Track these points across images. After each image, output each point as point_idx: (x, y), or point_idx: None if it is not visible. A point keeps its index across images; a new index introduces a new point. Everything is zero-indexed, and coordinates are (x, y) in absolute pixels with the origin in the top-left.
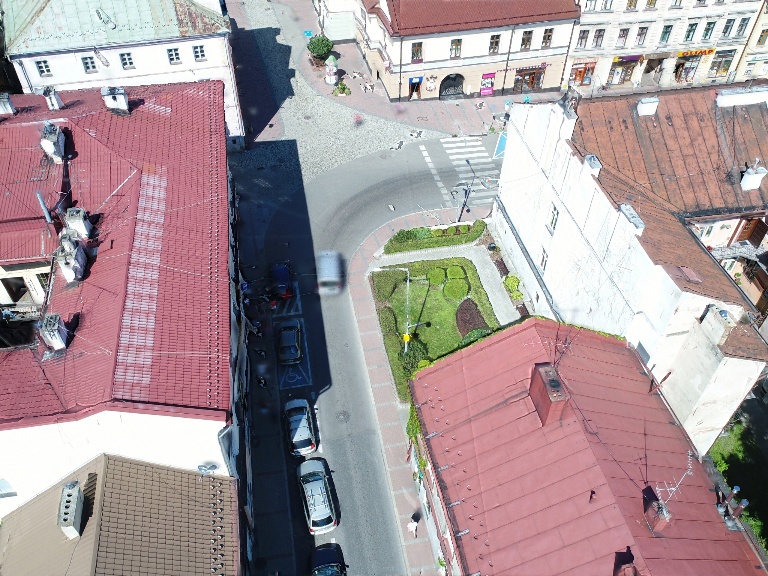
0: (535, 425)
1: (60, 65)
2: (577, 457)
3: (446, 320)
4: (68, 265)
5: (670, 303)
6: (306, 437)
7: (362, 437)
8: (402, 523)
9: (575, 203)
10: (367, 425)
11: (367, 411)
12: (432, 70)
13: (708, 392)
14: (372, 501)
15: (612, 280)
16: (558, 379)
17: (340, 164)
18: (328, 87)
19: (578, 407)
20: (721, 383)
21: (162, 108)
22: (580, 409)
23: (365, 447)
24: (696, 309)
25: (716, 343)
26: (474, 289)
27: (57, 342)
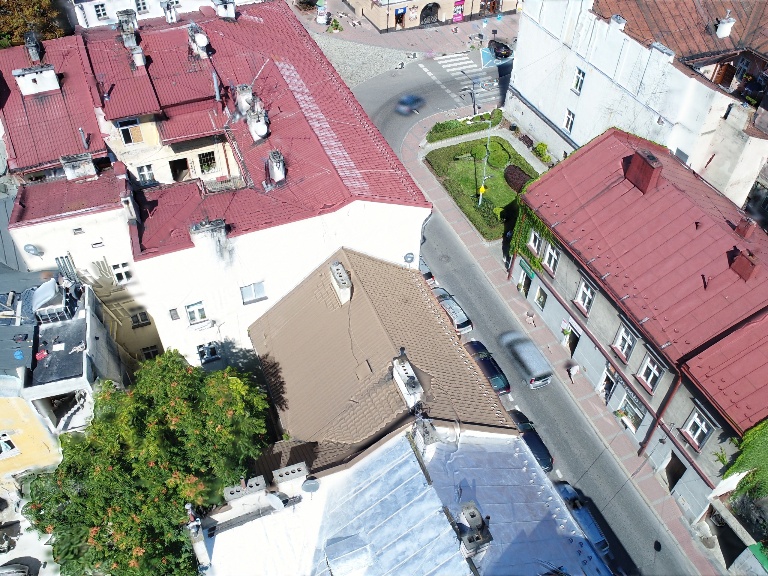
0: (637, 196)
1: (116, 7)
2: (677, 206)
3: (498, 182)
4: (259, 123)
5: (705, 105)
6: (427, 271)
7: (466, 270)
8: (521, 319)
9: (603, 59)
10: (466, 261)
11: (462, 252)
12: (414, 1)
13: (736, 172)
14: (492, 310)
15: (648, 107)
16: (652, 155)
17: (358, 84)
18: (321, 27)
19: (665, 178)
20: (745, 163)
21: (256, 18)
22: (667, 179)
23: (471, 276)
24: (722, 109)
25: (741, 129)
26: (514, 156)
27: (280, 173)
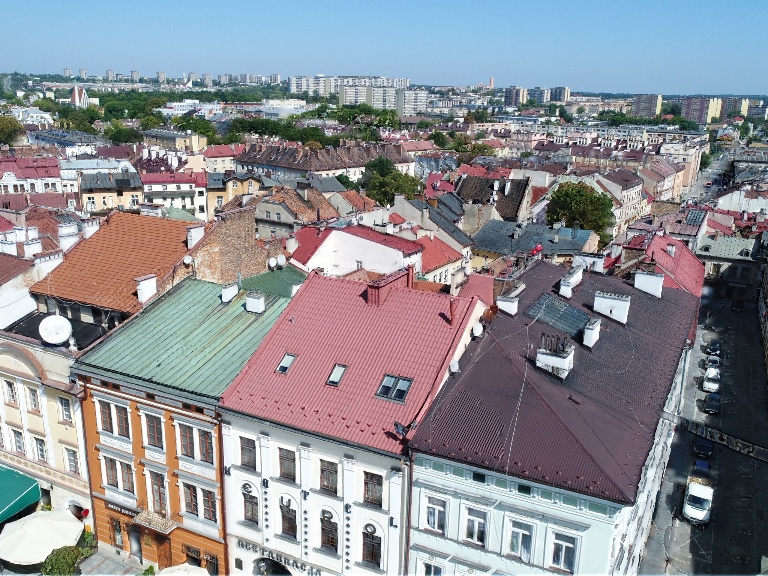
0: None
1: None
2: None
3: None
4: None
5: None
6: None
7: None
8: None
9: (757, 211)
10: None
11: None
12: None
13: None
14: None
15: None
16: None
17: None
18: None
19: None
20: None
21: None
22: None
23: None
24: None
25: None
26: None
27: None
